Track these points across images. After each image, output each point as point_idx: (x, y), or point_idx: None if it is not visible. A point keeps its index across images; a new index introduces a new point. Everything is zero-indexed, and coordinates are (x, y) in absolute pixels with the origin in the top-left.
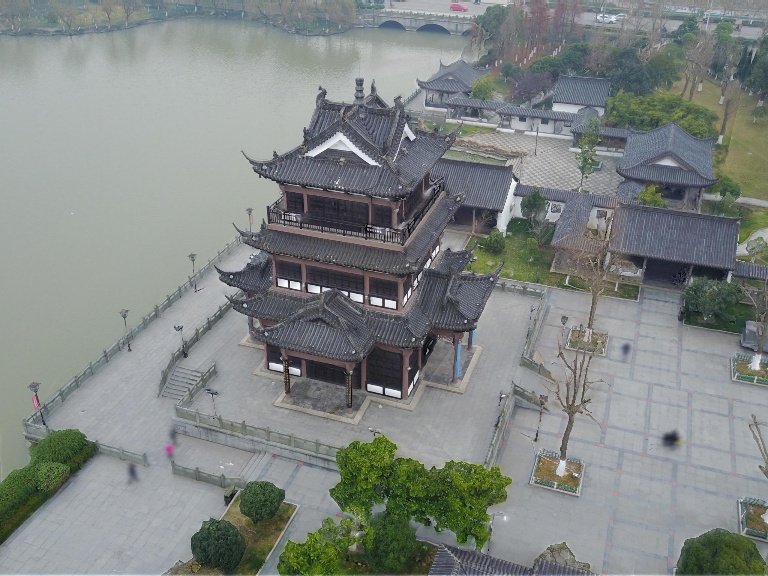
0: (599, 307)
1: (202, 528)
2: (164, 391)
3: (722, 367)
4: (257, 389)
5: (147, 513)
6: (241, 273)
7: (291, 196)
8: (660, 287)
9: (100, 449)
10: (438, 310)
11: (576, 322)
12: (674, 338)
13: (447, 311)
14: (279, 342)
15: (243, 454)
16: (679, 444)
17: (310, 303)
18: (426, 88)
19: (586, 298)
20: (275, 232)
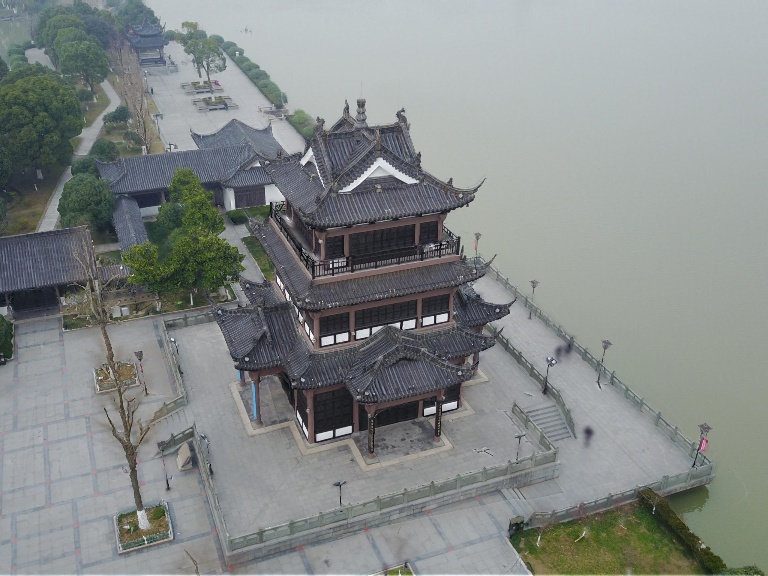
0: None
1: None
2: None
3: None
4: None
5: None
6: None
7: None
8: None
9: None
10: None
11: (174, 559)
12: None
13: None
14: None
15: None
16: (12, 448)
17: None
18: None
19: None
20: None
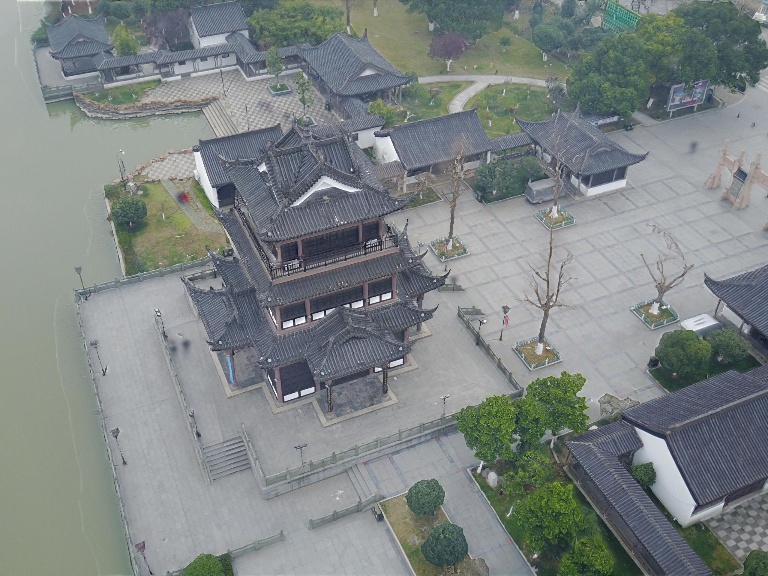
0: (425, 217)
1: (433, 542)
2: (211, 476)
3: (536, 225)
4: (294, 423)
5: (334, 570)
6: (224, 335)
7: (284, 247)
8: (444, 181)
9: (232, 555)
10: (404, 282)
11: (425, 237)
12: (491, 218)
13: (411, 280)
14: (334, 374)
15: (339, 479)
16: (570, 292)
17: (318, 329)
18: (61, 58)
19: (410, 214)
20: (278, 285)
